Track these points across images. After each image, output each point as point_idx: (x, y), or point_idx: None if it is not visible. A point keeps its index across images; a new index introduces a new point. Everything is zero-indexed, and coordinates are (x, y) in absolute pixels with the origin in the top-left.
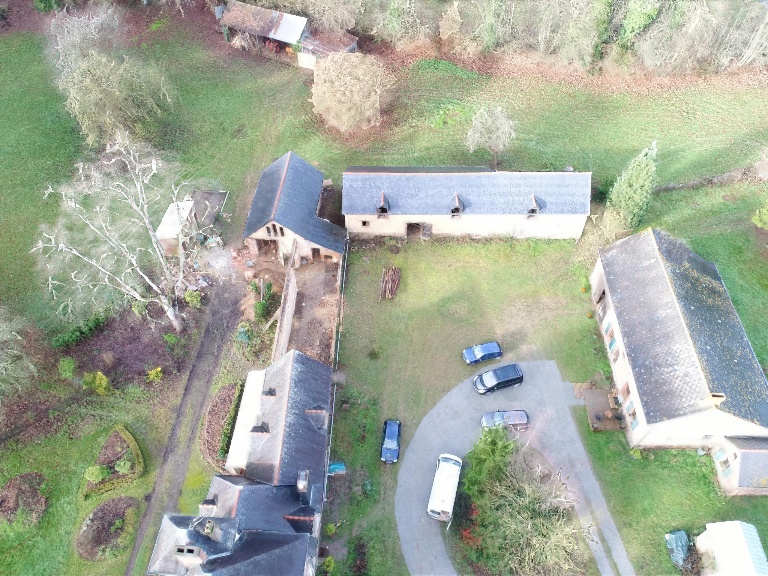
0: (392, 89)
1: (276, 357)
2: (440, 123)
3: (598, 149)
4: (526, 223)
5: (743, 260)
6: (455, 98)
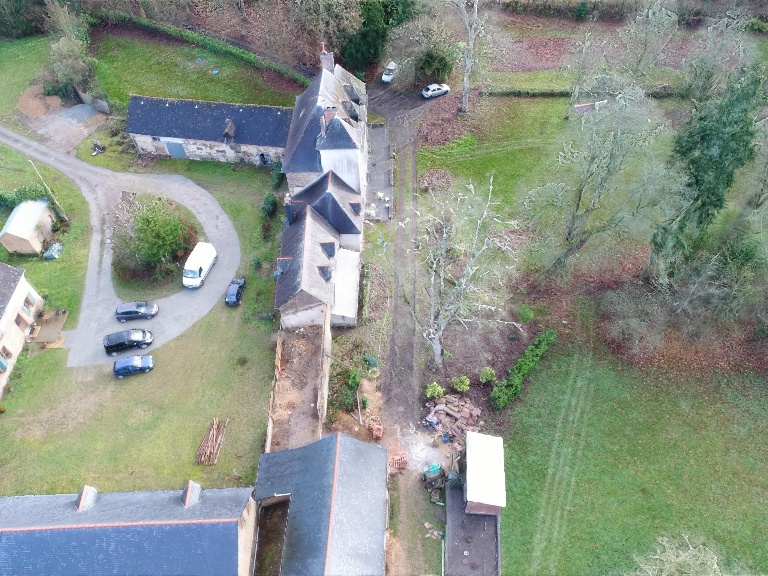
0: None
1: (325, 309)
2: None
3: None
4: None
5: None
6: None
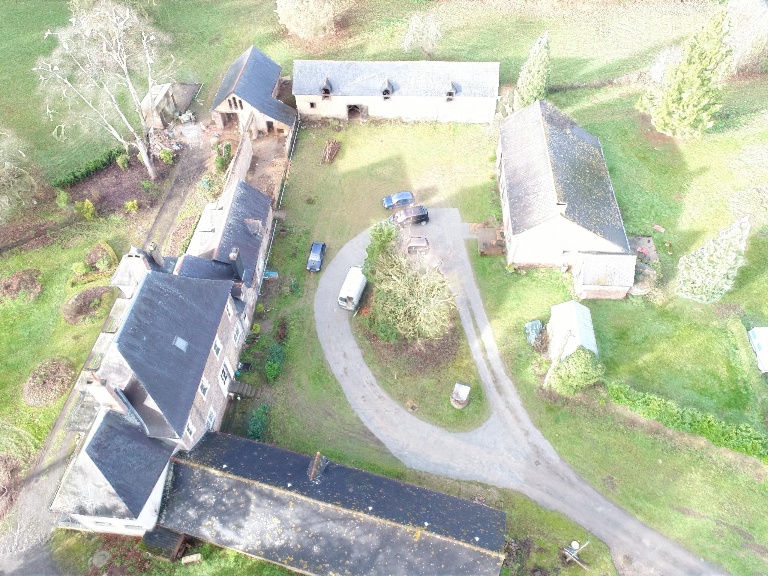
0: (350, 10)
1: None
2: (388, 36)
3: (520, 58)
4: (446, 107)
5: (627, 139)
6: (403, 18)
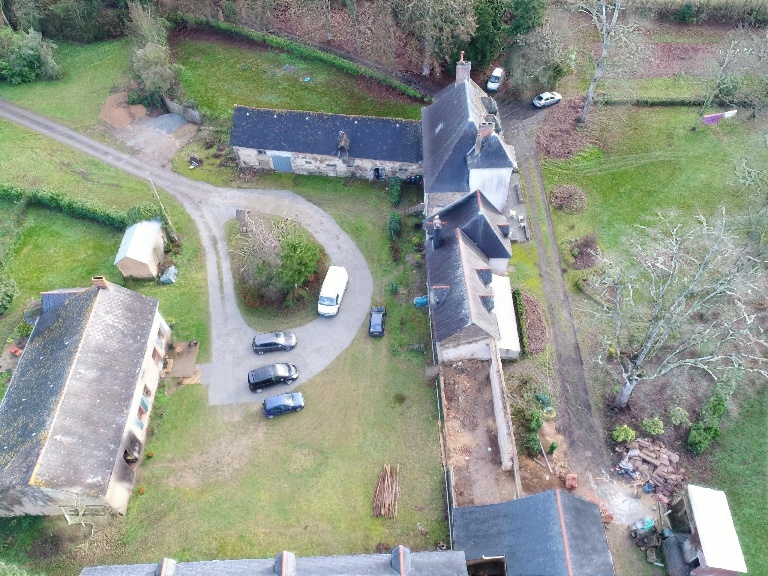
0: None
1: (493, 343)
2: None
3: None
4: None
5: None
6: None
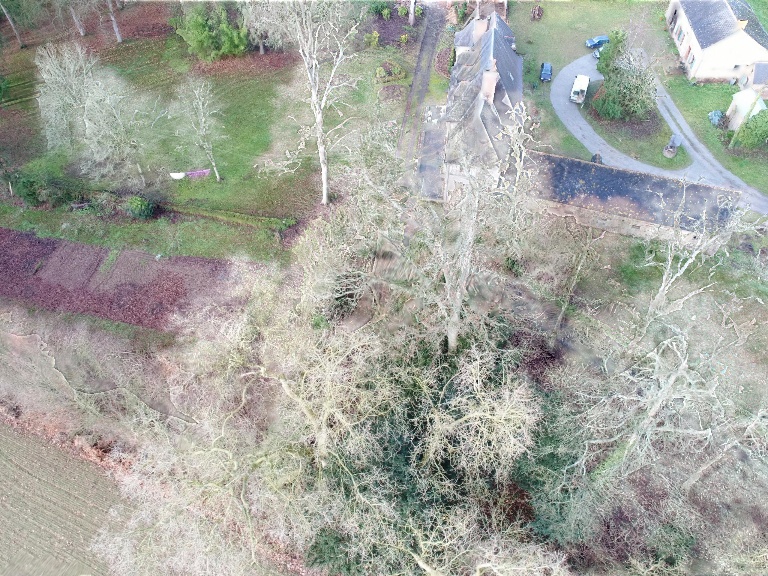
0: None
1: None
2: None
3: None
4: None
5: (767, 8)
6: None
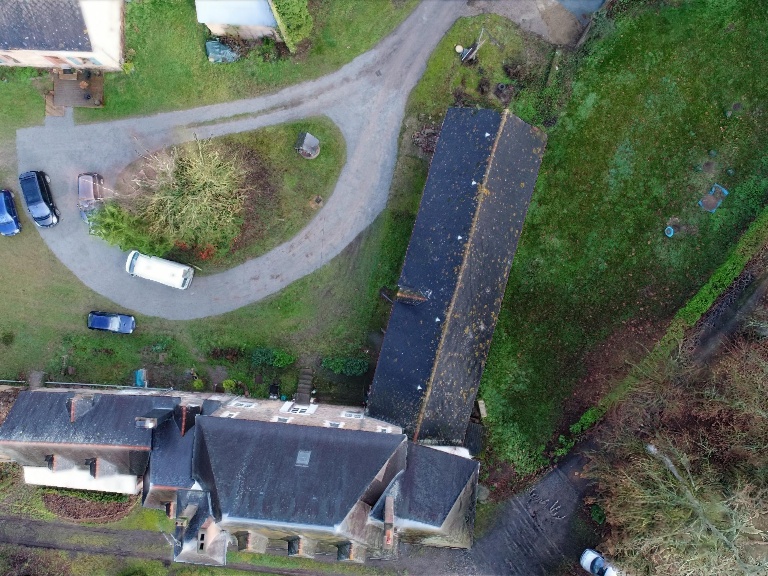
0: None
1: (5, 457)
2: None
3: None
4: None
5: None
6: None
